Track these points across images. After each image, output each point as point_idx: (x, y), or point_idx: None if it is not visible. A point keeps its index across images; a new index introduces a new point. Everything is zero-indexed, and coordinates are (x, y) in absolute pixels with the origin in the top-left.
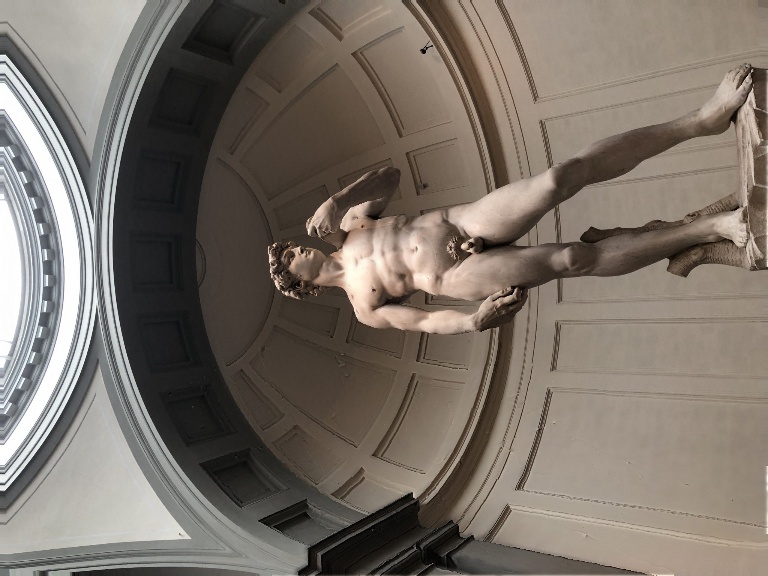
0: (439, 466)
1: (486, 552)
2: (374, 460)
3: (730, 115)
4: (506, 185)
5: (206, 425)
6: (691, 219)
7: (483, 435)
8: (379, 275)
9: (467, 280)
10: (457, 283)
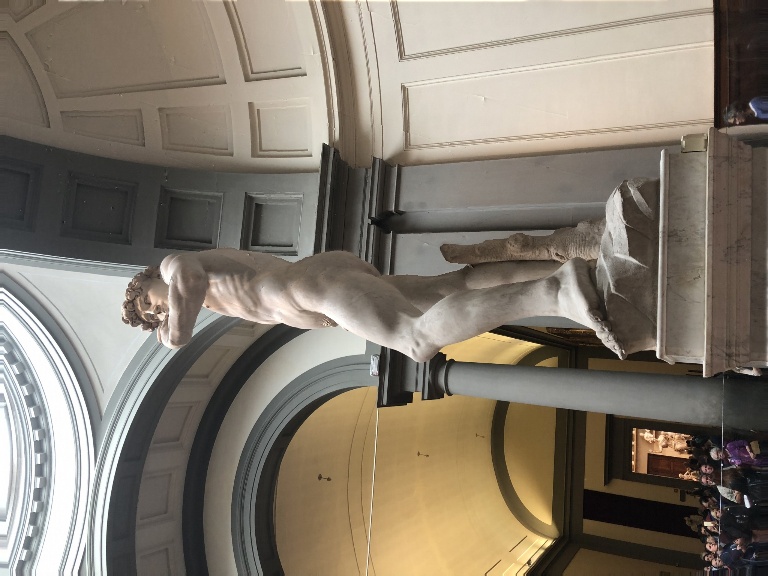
0: (314, 61)
1: (419, 183)
2: (251, 85)
3: None
4: (360, 328)
5: (112, 204)
6: None
7: (333, 7)
8: None
9: None
10: None
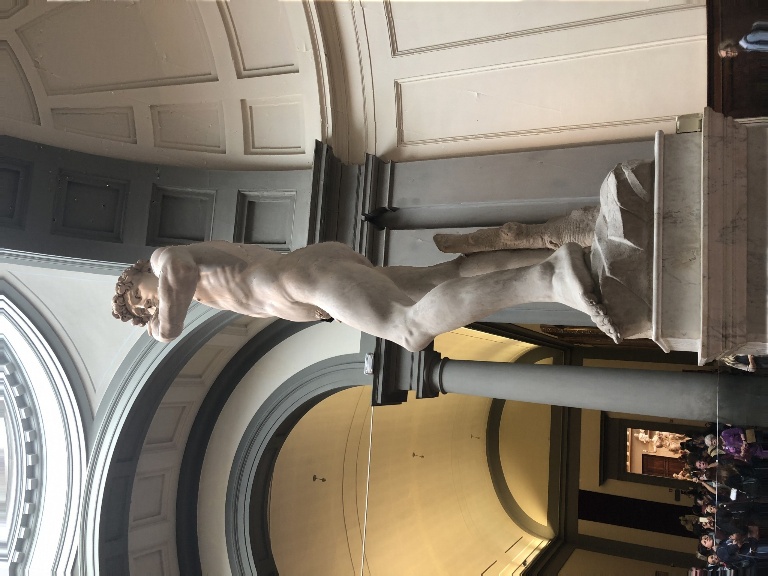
0: (306, 58)
1: (412, 179)
2: (243, 82)
3: None
4: (353, 318)
5: (103, 202)
6: None
7: (326, 3)
8: None
9: None
10: None
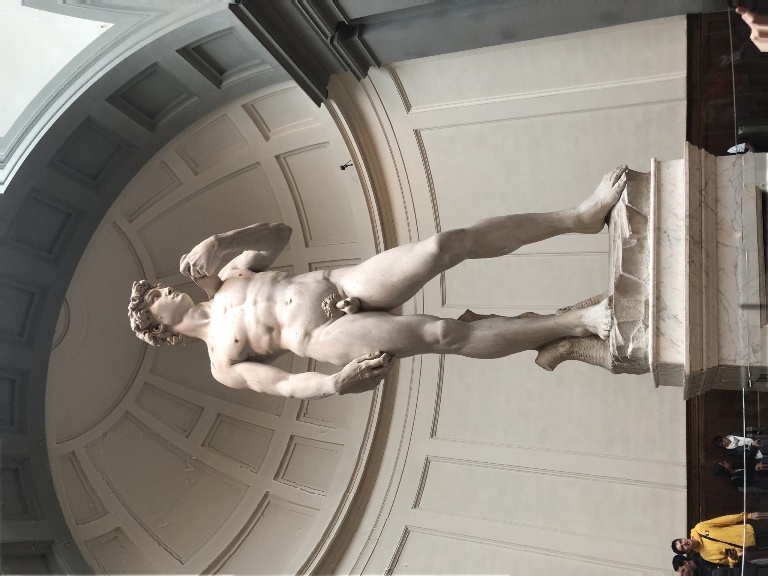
0: None
1: None
2: None
3: (605, 213)
4: None
5: (8, 503)
6: (562, 312)
7: (328, 568)
8: (246, 325)
9: (336, 339)
10: (325, 341)
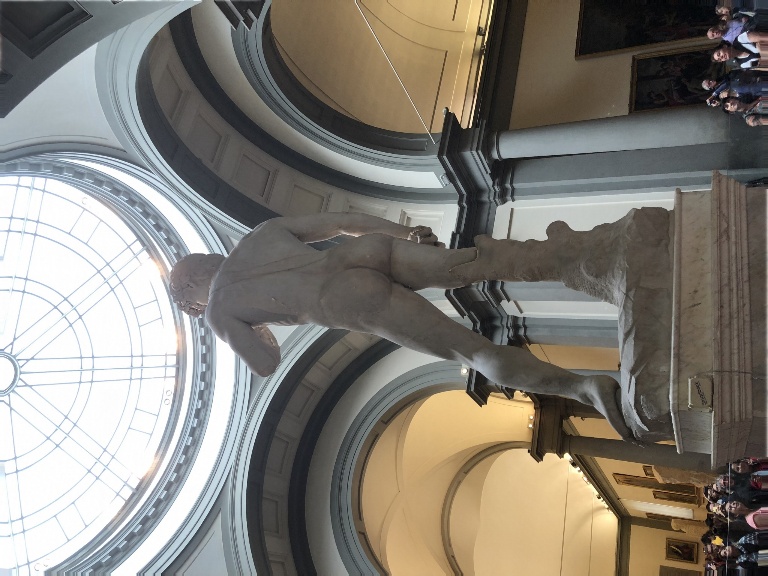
0: None
1: None
2: None
3: None
4: None
5: None
6: None
7: None
8: None
9: None
10: None
